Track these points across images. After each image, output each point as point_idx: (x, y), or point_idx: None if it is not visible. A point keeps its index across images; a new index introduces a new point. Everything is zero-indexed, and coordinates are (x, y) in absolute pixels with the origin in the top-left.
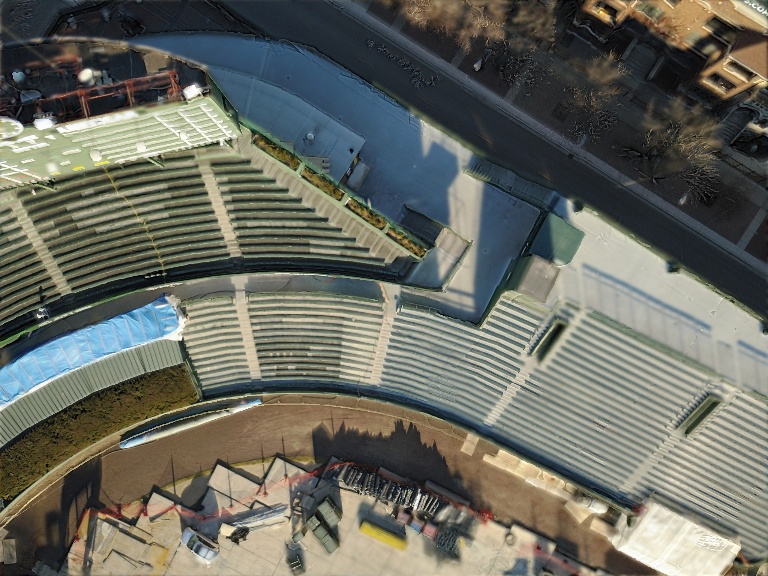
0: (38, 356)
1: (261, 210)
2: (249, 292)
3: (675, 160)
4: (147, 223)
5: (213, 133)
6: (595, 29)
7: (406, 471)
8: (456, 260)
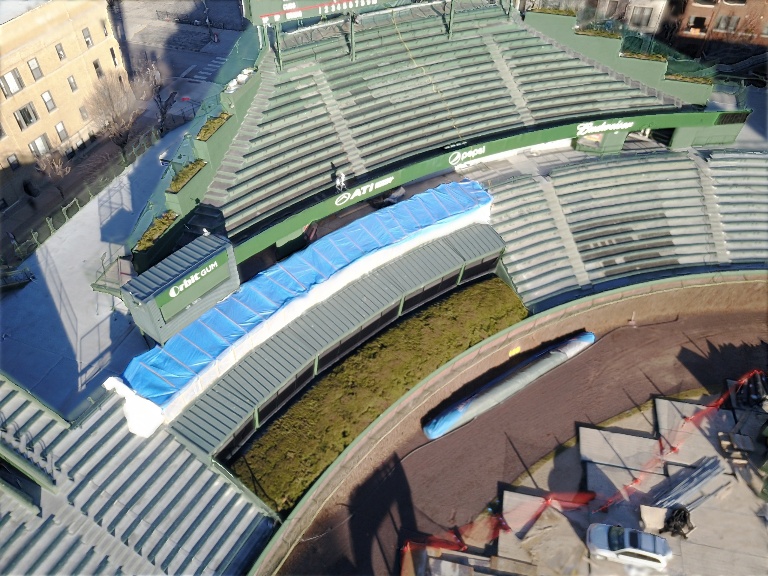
0: (335, 239)
1: (545, 72)
2: (546, 175)
3: None
4: (441, 92)
5: None
6: (687, 55)
7: None
8: (735, 104)
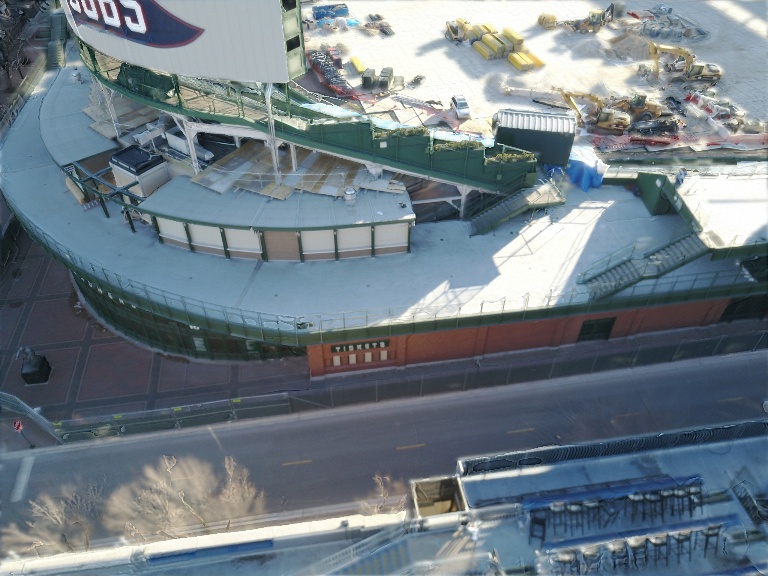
0: None
1: None
2: None
3: (4, 77)
4: None
5: None
6: None
7: (312, 76)
8: None
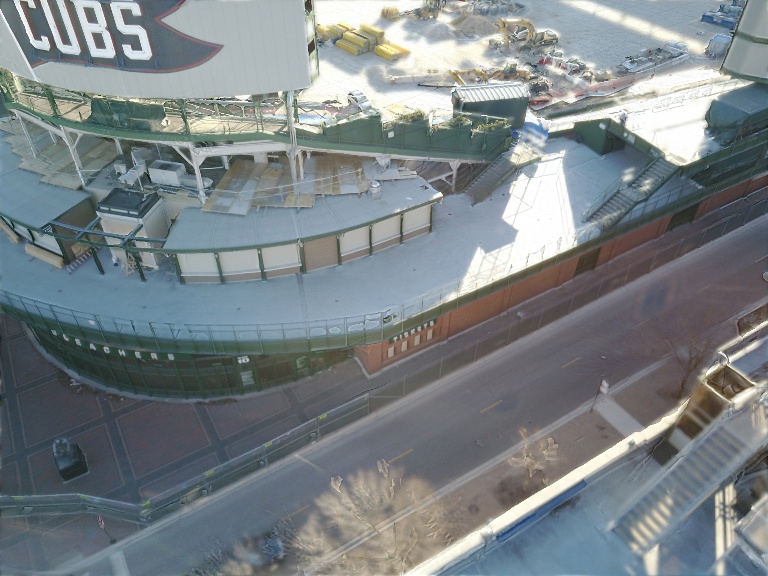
0: None
1: None
2: None
3: None
4: None
5: None
6: None
7: None
8: None
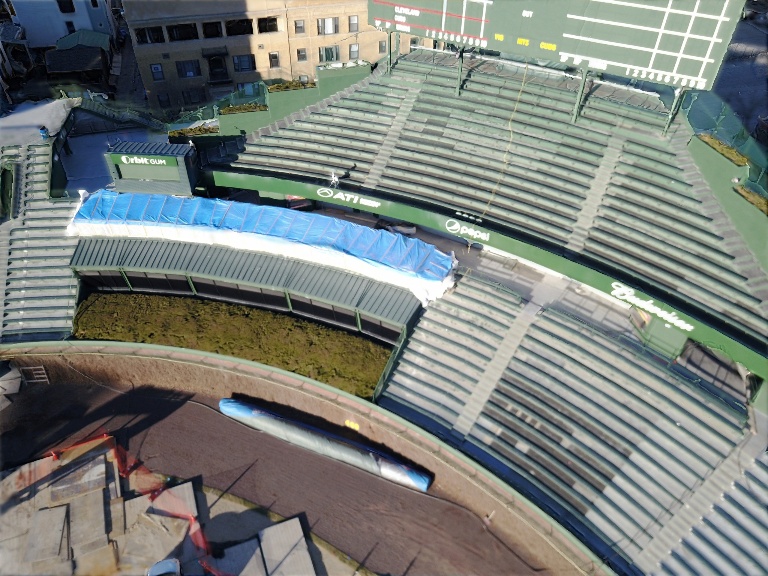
0: (285, 215)
1: (648, 209)
2: None
3: None
4: (509, 164)
5: (692, 53)
6: None
7: None
8: None
